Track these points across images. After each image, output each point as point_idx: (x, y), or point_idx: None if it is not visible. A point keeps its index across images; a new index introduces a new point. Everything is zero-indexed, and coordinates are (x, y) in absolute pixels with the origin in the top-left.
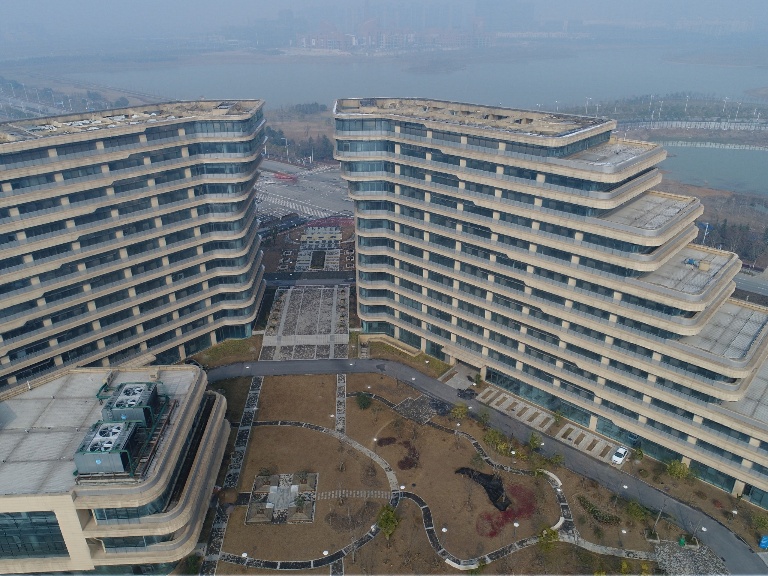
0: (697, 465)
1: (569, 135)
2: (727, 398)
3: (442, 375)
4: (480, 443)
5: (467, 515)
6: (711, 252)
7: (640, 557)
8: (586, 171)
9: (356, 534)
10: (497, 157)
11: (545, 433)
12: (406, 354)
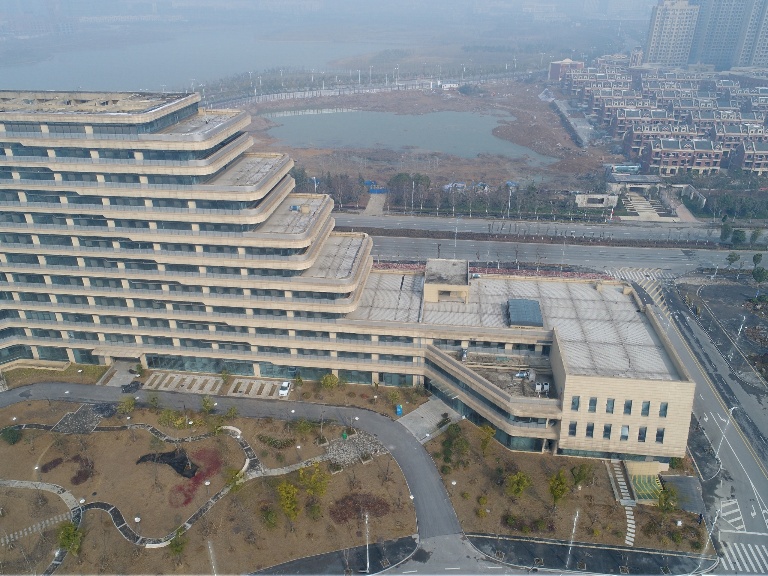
0: (343, 373)
1: (154, 110)
2: (347, 311)
3: (100, 378)
4: (156, 427)
5: (158, 496)
6: (310, 197)
7: None
8: (179, 142)
9: (38, 570)
10: (87, 141)
11: (217, 395)
12: (53, 371)
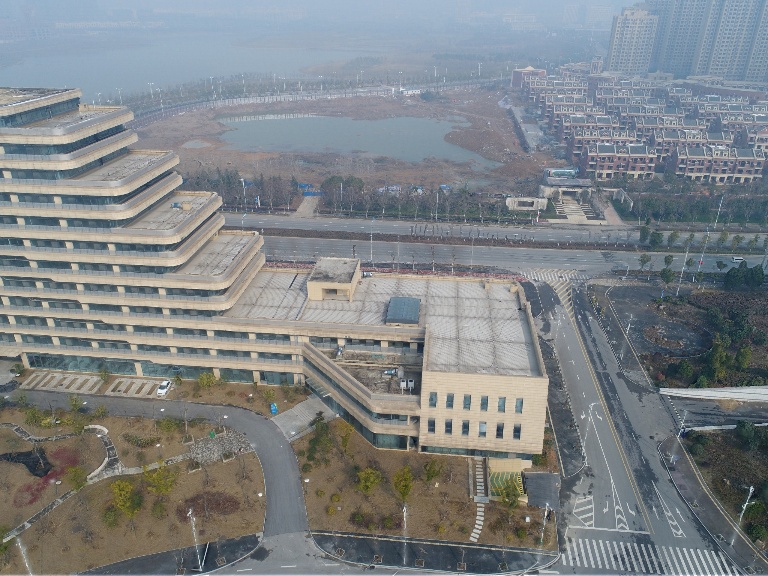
0: (225, 371)
1: (15, 104)
2: (221, 308)
3: None
4: (22, 426)
5: (3, 496)
6: (198, 195)
7: (177, 460)
8: (37, 136)
9: None
10: None
11: (94, 394)
12: None
